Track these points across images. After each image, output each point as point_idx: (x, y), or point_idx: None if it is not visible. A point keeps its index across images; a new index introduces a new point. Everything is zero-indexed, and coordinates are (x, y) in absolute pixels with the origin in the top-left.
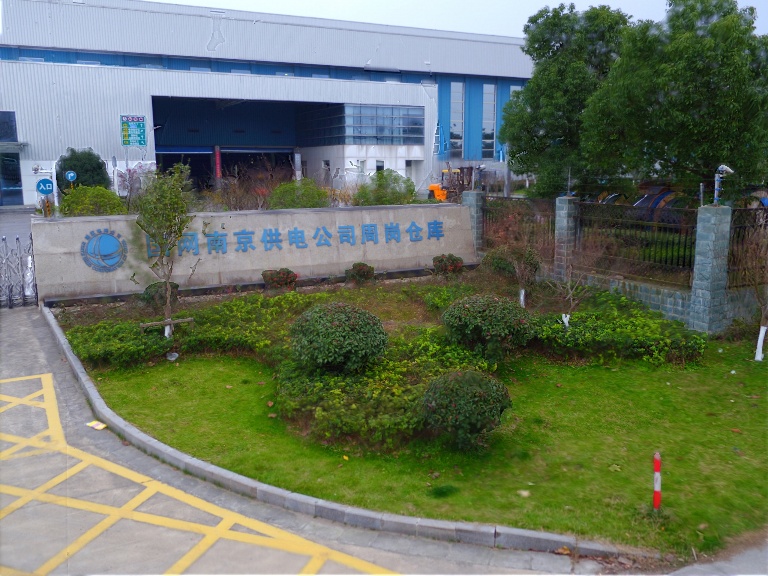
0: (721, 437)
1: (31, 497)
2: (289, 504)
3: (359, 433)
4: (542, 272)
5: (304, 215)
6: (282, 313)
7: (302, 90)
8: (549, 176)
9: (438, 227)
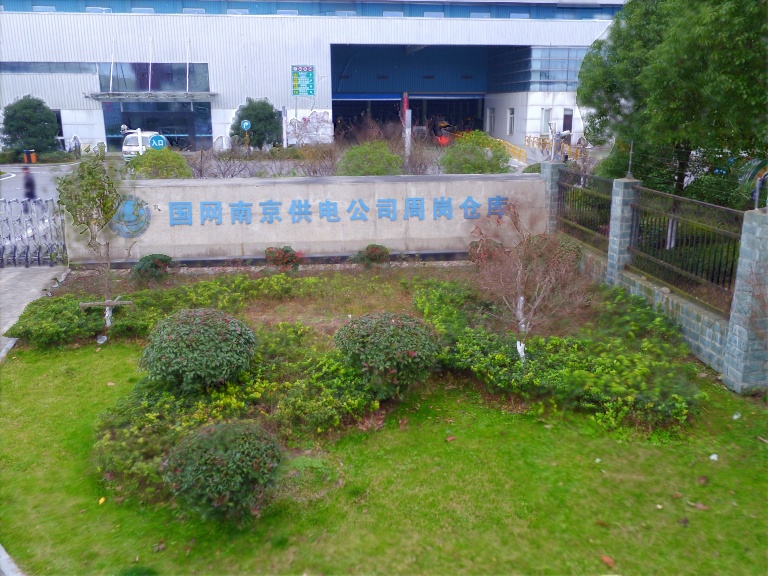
0: (572, 568)
1: None
2: None
3: None
4: (598, 269)
5: (339, 186)
6: None
7: (485, 32)
8: (619, 150)
9: (501, 203)
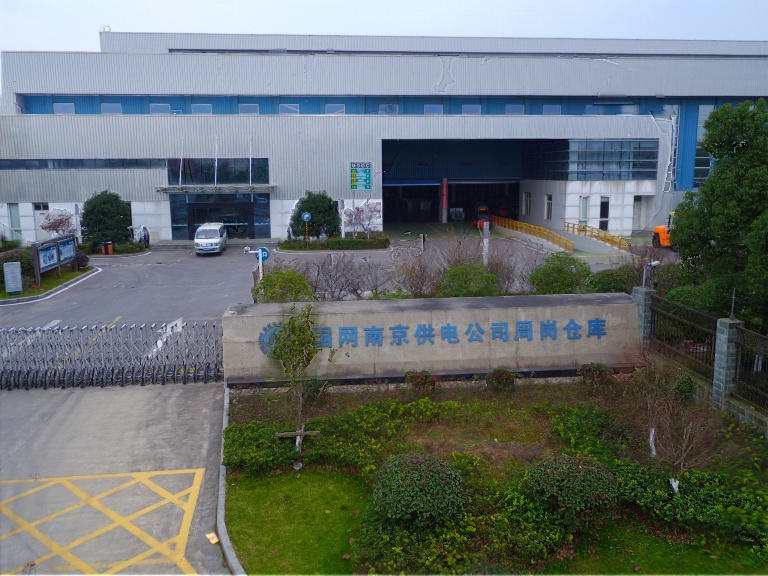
0: None
1: None
2: None
3: None
4: (702, 393)
5: (458, 311)
6: None
7: (525, 128)
8: (717, 290)
9: (600, 325)
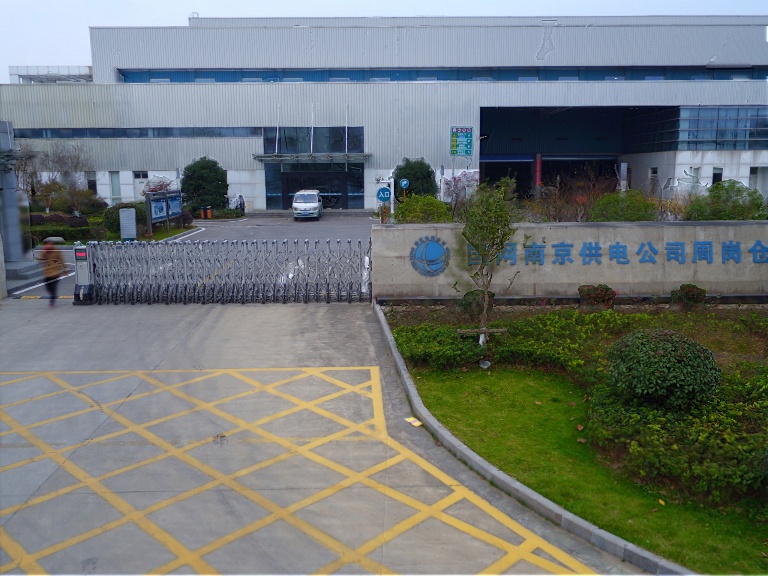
0: None
1: (357, 479)
2: (595, 540)
3: (680, 478)
4: None
5: (628, 229)
6: (597, 331)
7: (633, 94)
8: None
9: None
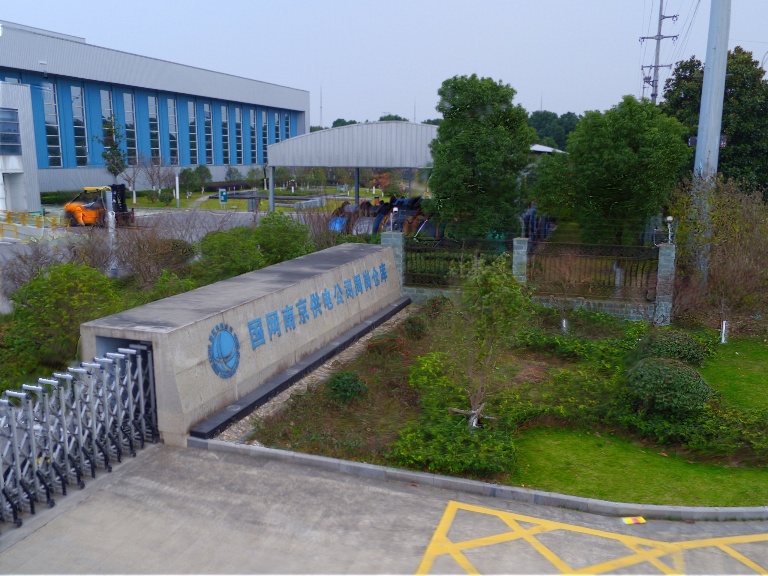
0: None
1: None
2: None
3: None
4: None
5: (326, 274)
6: None
7: None
8: (489, 220)
9: (383, 269)
